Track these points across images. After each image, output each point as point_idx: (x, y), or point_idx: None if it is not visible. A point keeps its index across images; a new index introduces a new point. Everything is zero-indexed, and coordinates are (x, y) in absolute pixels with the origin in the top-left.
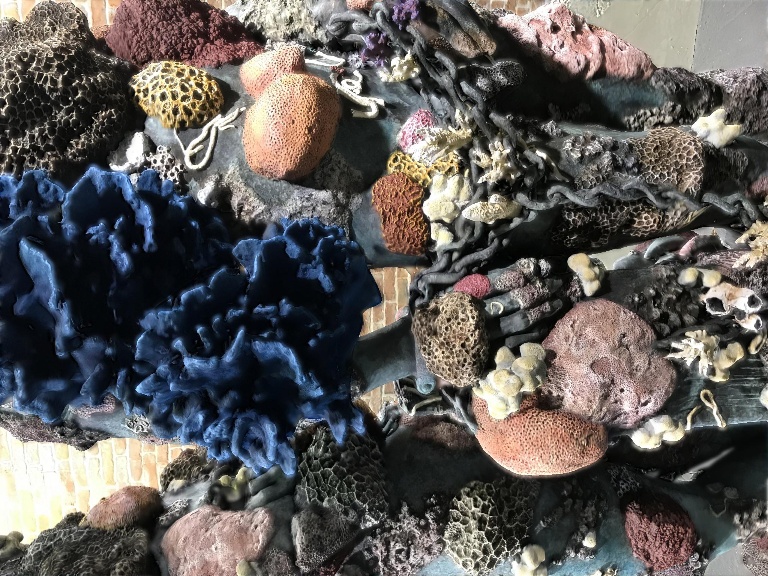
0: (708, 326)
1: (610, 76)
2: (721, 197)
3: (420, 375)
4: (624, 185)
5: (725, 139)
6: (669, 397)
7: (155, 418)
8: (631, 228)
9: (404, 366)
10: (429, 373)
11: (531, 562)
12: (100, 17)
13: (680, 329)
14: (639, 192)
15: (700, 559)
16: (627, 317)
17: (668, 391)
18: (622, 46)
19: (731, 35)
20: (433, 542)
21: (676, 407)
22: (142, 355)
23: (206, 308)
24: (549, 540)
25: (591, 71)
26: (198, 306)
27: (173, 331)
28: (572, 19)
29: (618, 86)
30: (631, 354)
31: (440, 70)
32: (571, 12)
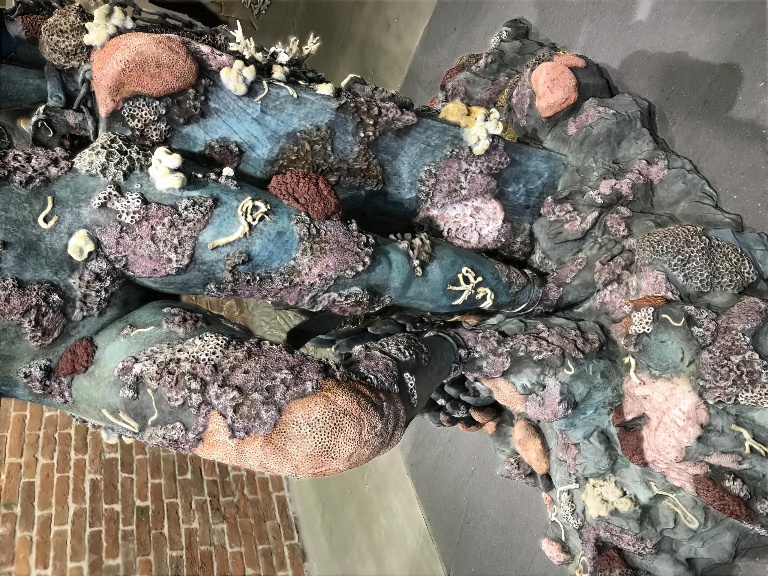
0: None
1: None
2: None
3: (48, 78)
4: None
5: None
6: None
7: None
8: None
9: (34, 73)
10: (56, 76)
11: (161, 147)
12: None
13: None
14: (194, 28)
15: (362, 233)
16: None
17: None
18: None
19: None
20: (60, 158)
21: None
22: None
23: None
24: (186, 167)
25: None
26: None
27: None
28: None
29: None
30: None
31: None
32: None
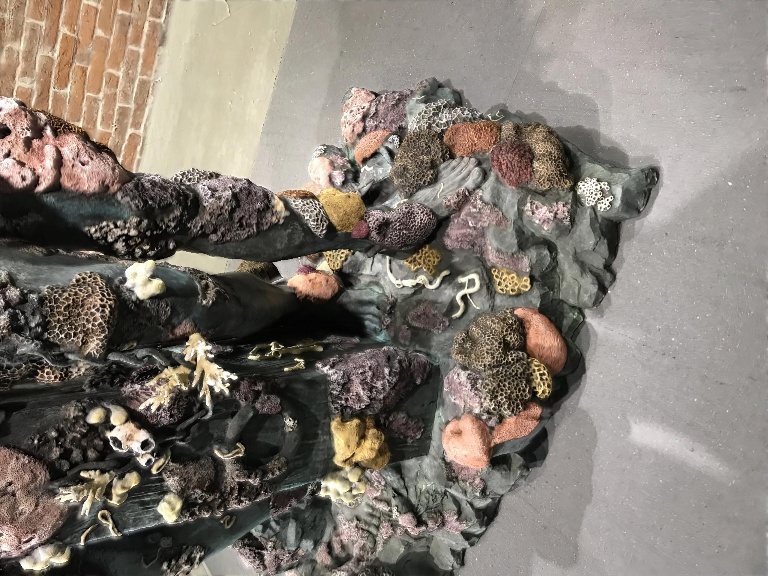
0: (106, 463)
1: (66, 190)
2: (133, 350)
3: None
4: (18, 349)
5: (148, 294)
6: (63, 524)
7: None
8: (35, 378)
9: None
10: None
11: None
12: None
13: (81, 464)
14: None
15: None
16: (18, 464)
17: (57, 524)
18: (84, 160)
19: (306, 65)
20: None
21: (71, 529)
22: None
23: None
24: None
25: (40, 186)
26: None
27: None
28: (28, 122)
29: (76, 200)
30: (17, 499)
31: None
32: (28, 114)
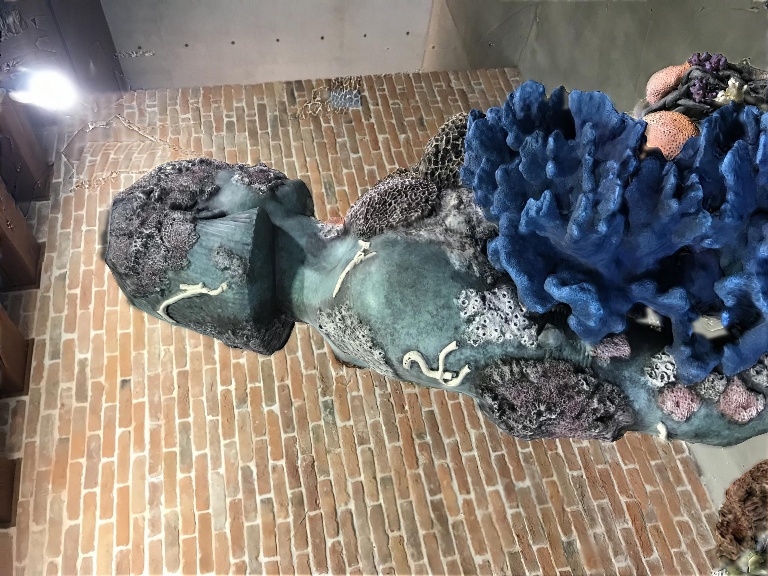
0: None
1: None
2: None
3: None
4: None
5: None
6: None
7: (685, 342)
8: None
9: None
10: None
11: None
12: (264, 472)
13: None
14: None
15: None
16: None
17: None
18: None
19: None
20: None
21: None
22: (704, 158)
23: (735, 126)
24: None
25: None
26: (729, 124)
27: (719, 141)
28: None
29: None
30: None
31: (759, 90)
32: None
